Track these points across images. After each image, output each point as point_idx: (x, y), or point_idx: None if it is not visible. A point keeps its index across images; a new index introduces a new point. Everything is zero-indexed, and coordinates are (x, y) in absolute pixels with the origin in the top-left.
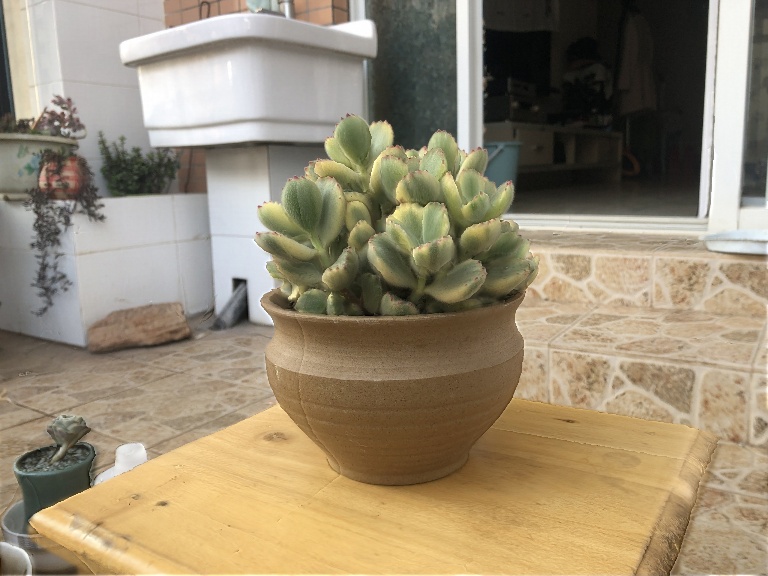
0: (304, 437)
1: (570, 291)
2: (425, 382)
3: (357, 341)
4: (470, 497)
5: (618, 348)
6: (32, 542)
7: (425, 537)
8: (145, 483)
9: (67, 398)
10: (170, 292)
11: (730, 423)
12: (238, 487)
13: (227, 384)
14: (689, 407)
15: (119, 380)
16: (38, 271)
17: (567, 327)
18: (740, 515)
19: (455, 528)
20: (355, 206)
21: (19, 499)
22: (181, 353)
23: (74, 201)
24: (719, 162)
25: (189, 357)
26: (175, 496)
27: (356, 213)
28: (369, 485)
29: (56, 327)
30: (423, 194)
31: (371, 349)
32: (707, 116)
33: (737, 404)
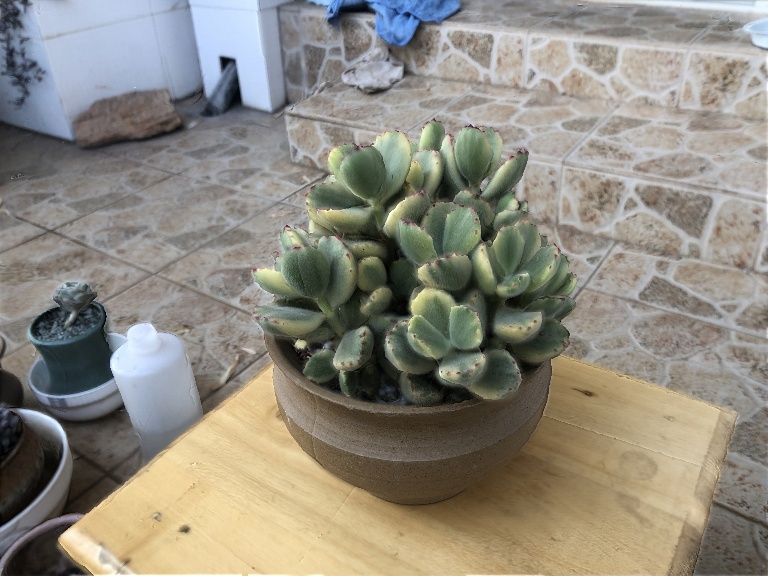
0: None
1: (591, 85)
2: (447, 461)
3: (374, 421)
4: (486, 526)
5: (636, 169)
6: (62, 402)
7: None
8: (165, 493)
9: (66, 209)
10: (154, 77)
11: (739, 250)
12: (257, 502)
13: (227, 190)
14: (700, 233)
15: (115, 184)
16: (5, 57)
17: (584, 137)
18: (732, 355)
19: None
20: (368, 265)
21: (41, 356)
22: (175, 148)
23: None
24: None
25: (184, 153)
26: (196, 516)
27: (369, 272)
28: (386, 502)
29: (38, 118)
30: (451, 282)
31: (389, 429)
32: None
33: (750, 233)
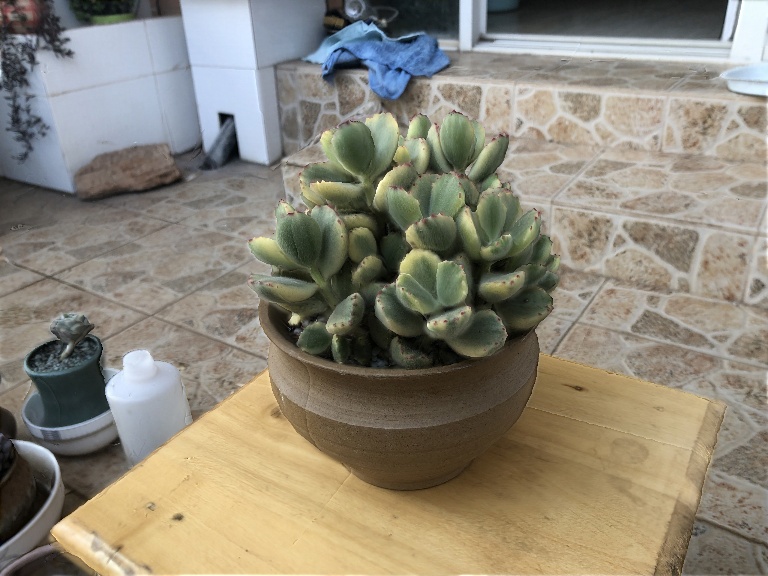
0: None
1: (576, 132)
2: (438, 429)
3: (366, 388)
4: (480, 507)
5: (623, 206)
6: (55, 434)
7: (437, 568)
8: (159, 485)
9: (65, 256)
10: (154, 132)
11: (727, 283)
12: (251, 492)
13: (224, 237)
14: (688, 267)
15: (114, 233)
16: (10, 114)
17: (571, 178)
18: (726, 383)
19: (466, 555)
20: (358, 235)
21: (35, 390)
22: (173, 199)
23: (35, 36)
24: None
25: (182, 204)
26: (190, 505)
27: (360, 242)
28: (380, 489)
29: (40, 172)
30: (437, 241)
31: (381, 396)
32: None
33: (737, 265)
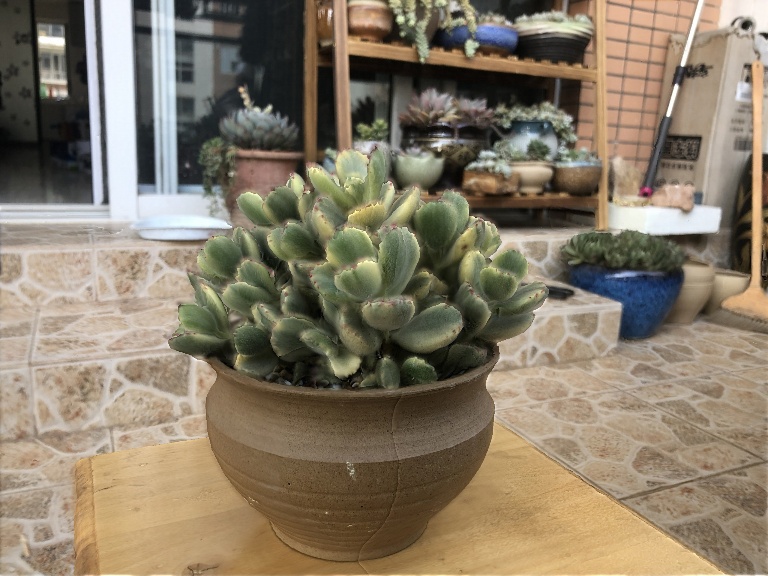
0: (231, 553)
1: None
2: None
3: (454, 402)
4: (471, 515)
5: (111, 350)
6: None
7: (519, 561)
8: None
9: None
10: None
11: None
12: None
13: None
14: (187, 390)
15: None
16: None
17: (31, 338)
18: None
19: (516, 542)
20: None
21: None
22: None
23: None
24: (115, 151)
25: None
26: None
27: None
28: (399, 554)
29: None
30: None
31: (461, 406)
32: (93, 103)
33: None
